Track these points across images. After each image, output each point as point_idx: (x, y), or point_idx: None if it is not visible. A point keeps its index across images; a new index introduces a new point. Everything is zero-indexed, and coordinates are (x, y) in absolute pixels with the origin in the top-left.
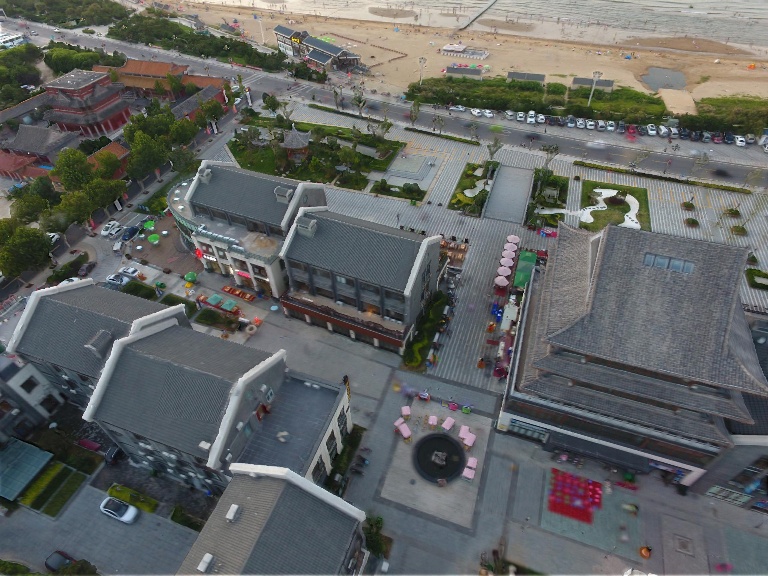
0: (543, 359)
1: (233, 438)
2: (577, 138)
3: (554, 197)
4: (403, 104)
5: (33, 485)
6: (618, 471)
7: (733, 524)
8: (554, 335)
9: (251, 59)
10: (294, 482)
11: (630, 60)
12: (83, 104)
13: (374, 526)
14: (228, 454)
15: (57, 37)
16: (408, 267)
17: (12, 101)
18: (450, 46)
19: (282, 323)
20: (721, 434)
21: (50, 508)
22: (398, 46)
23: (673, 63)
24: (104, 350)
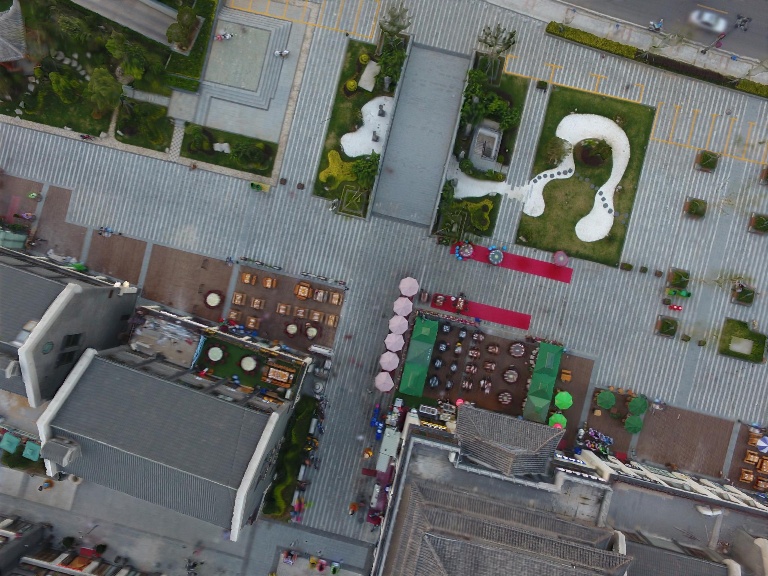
0: None
1: None
2: None
3: (494, 141)
4: None
5: None
6: None
7: None
8: None
9: None
10: None
11: None
12: None
13: None
14: None
15: None
16: (228, 509)
17: None
18: None
19: None
20: None
21: None
22: None
23: None
24: None
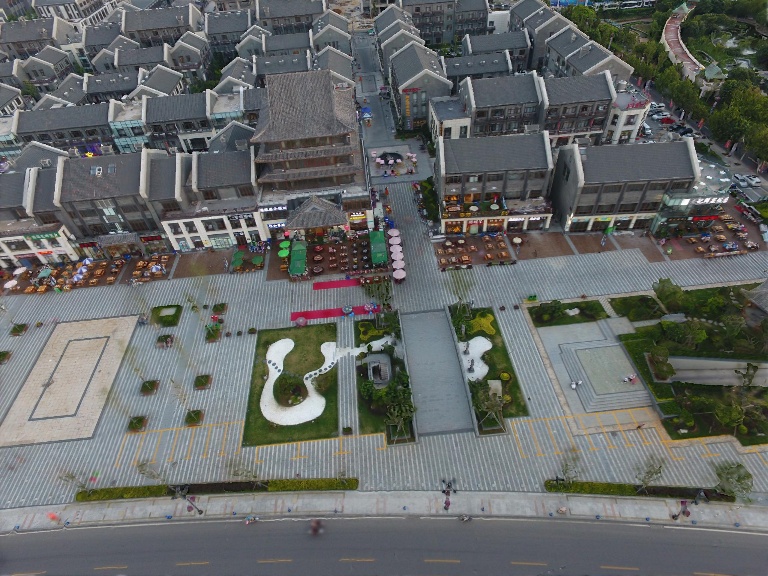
0: None
1: None
2: None
3: None
4: None
5: None
6: None
7: None
8: None
9: None
10: None
11: None
12: None
13: None
14: None
15: None
16: None
17: None
18: None
19: None
20: None
21: None
22: None
23: None
24: None
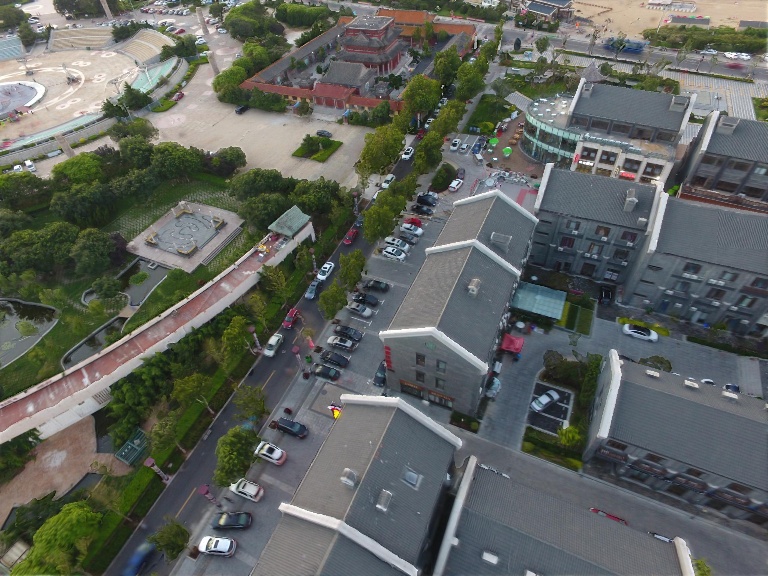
0: None
1: None
2: None
3: None
4: (648, 49)
5: None
6: None
7: None
8: None
9: (474, 11)
10: None
11: None
12: (382, 44)
13: None
14: None
15: None
16: None
17: None
18: None
19: None
20: None
21: (582, 329)
22: (595, 1)
23: None
24: None
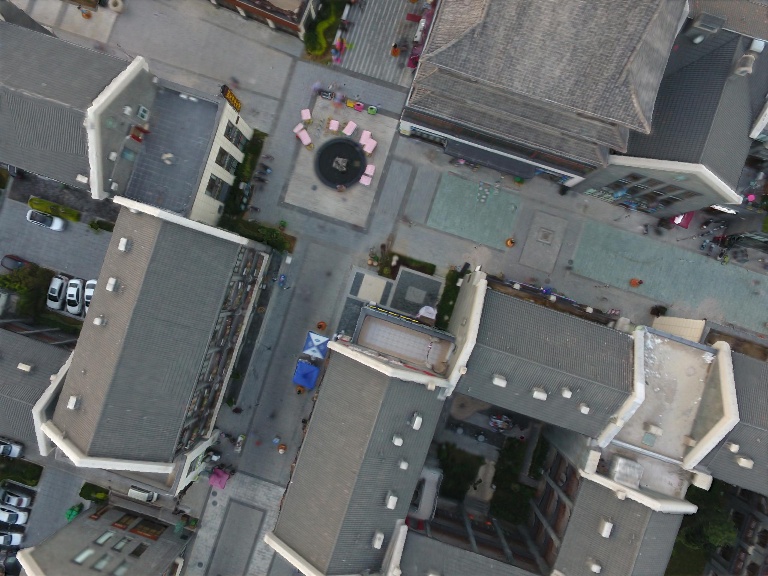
0: (429, 76)
1: (111, 168)
2: None
3: None
4: None
5: None
6: None
7: (596, 218)
8: (436, 53)
9: None
10: (169, 221)
11: None
12: None
13: None
14: (112, 184)
15: None
16: None
17: None
18: None
19: None
20: (599, 155)
21: None
22: None
23: None
24: None
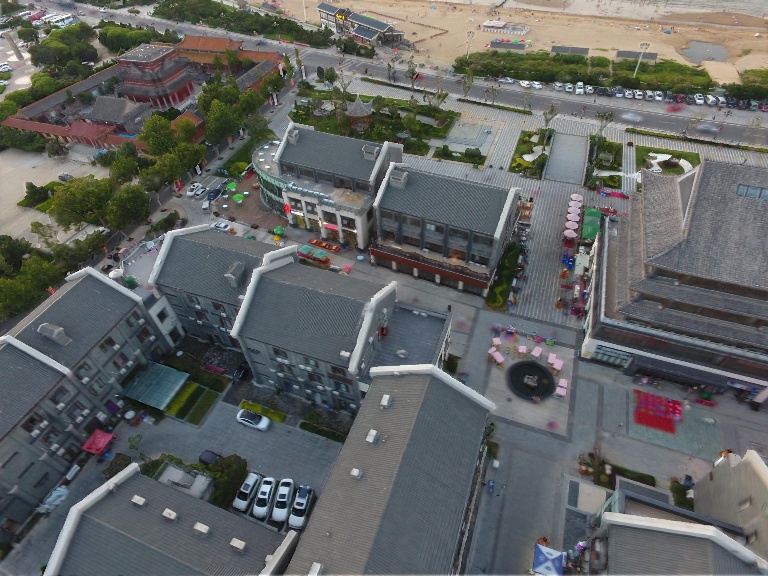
0: (640, 282)
1: (365, 350)
2: (626, 107)
3: (609, 161)
4: (452, 77)
5: (175, 399)
6: (694, 391)
7: None
8: (654, 258)
9: (299, 35)
10: (438, 375)
11: (670, 34)
12: (154, 76)
13: (486, 429)
14: (362, 363)
15: (104, 17)
16: (497, 213)
17: (77, 76)
18: (490, 22)
19: (369, 271)
20: None
21: (193, 418)
22: (437, 23)
23: (713, 37)
24: (239, 280)
